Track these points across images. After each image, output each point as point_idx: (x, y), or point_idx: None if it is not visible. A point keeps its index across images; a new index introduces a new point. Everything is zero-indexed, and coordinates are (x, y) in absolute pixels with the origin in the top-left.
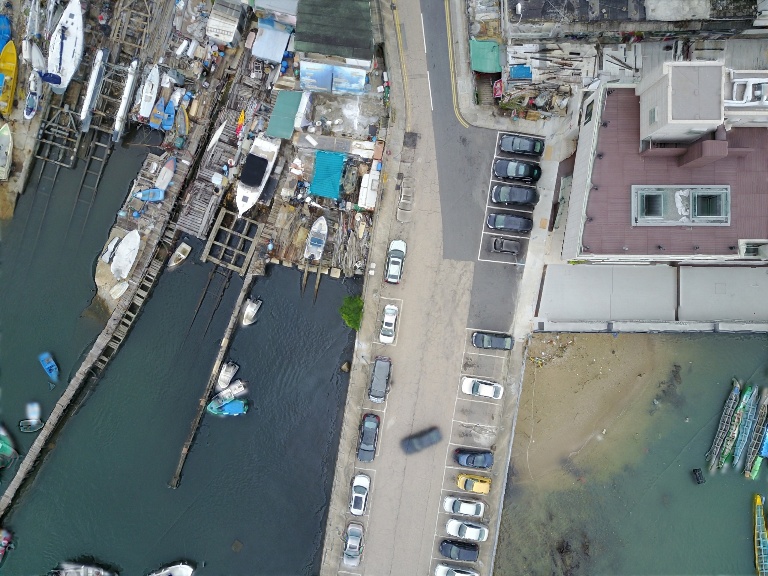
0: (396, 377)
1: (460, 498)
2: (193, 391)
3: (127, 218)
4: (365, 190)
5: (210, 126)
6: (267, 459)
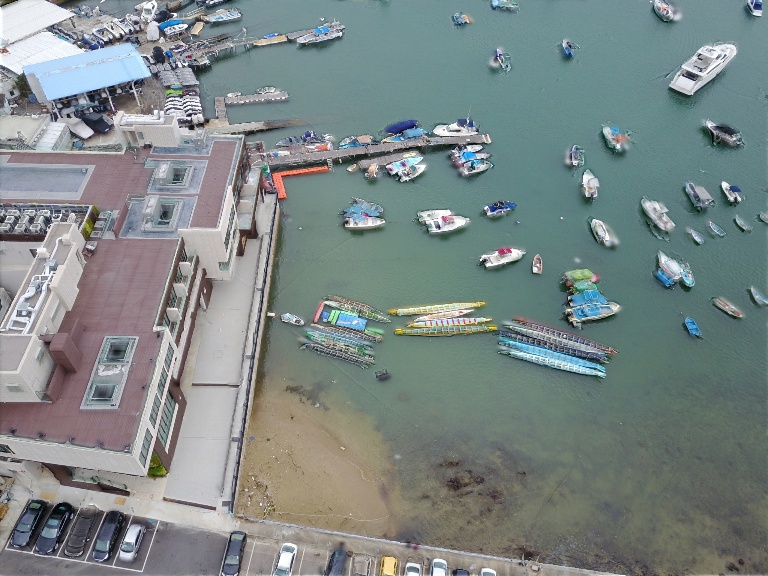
0: None
1: None
2: None
3: None
4: None
5: None
6: None
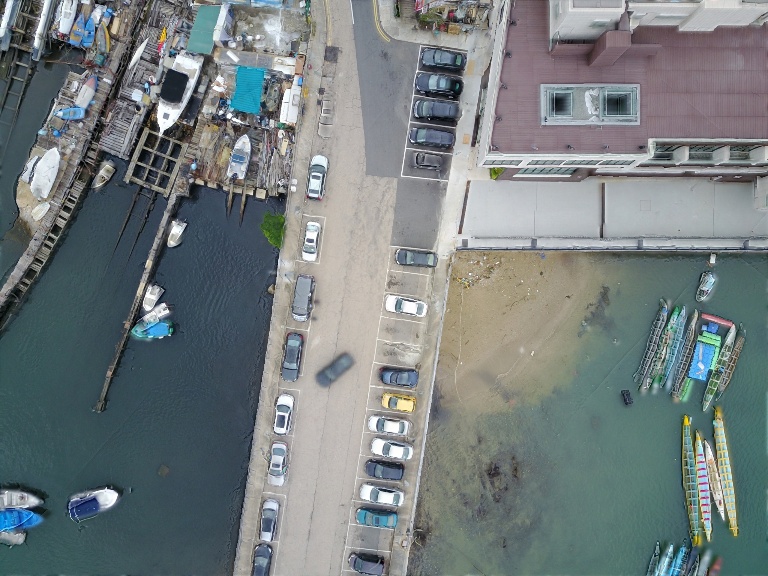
0: (320, 296)
1: (384, 416)
2: (117, 314)
3: (48, 138)
4: (286, 105)
5: (132, 44)
6: (194, 384)
